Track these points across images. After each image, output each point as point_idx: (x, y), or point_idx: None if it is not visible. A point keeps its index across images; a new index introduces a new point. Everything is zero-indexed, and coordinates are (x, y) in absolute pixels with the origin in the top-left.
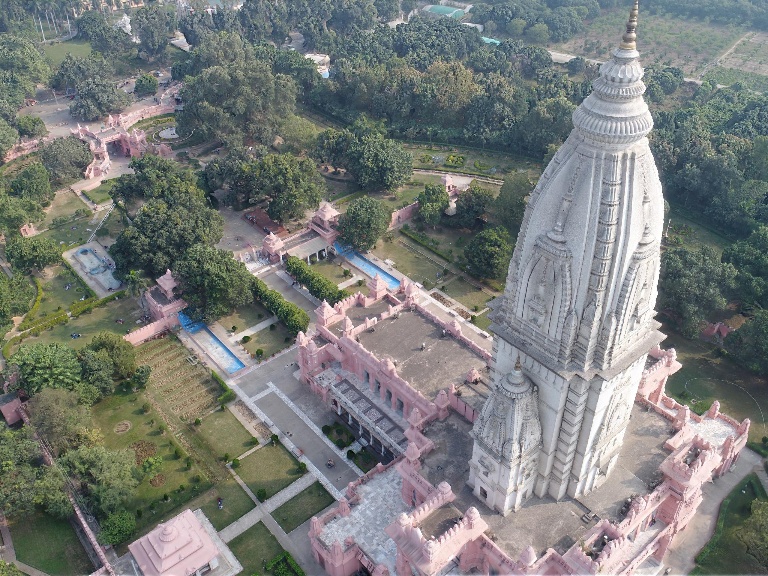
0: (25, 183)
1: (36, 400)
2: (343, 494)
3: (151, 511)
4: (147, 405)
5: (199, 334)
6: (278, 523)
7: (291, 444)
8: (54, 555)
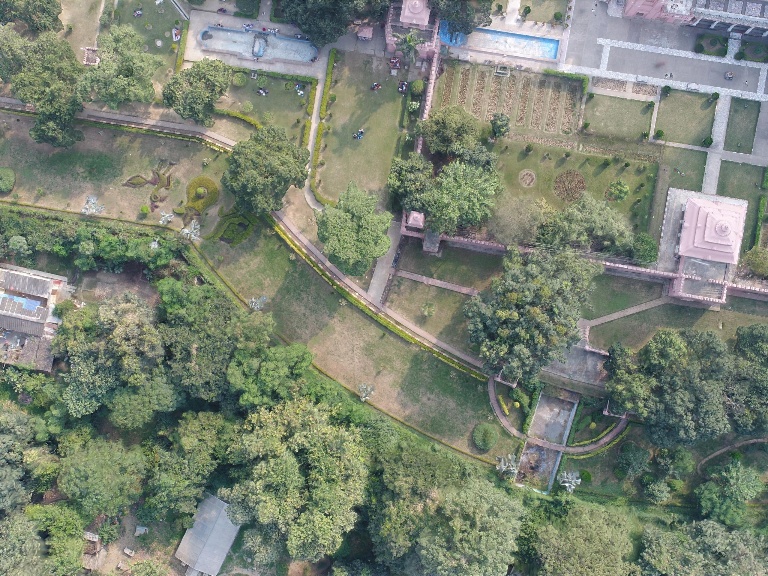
0: (19, 4)
1: (495, 225)
2: (762, 93)
3: (638, 218)
4: (532, 146)
5: (471, 40)
6: (737, 152)
7: (680, 83)
8: (610, 297)
